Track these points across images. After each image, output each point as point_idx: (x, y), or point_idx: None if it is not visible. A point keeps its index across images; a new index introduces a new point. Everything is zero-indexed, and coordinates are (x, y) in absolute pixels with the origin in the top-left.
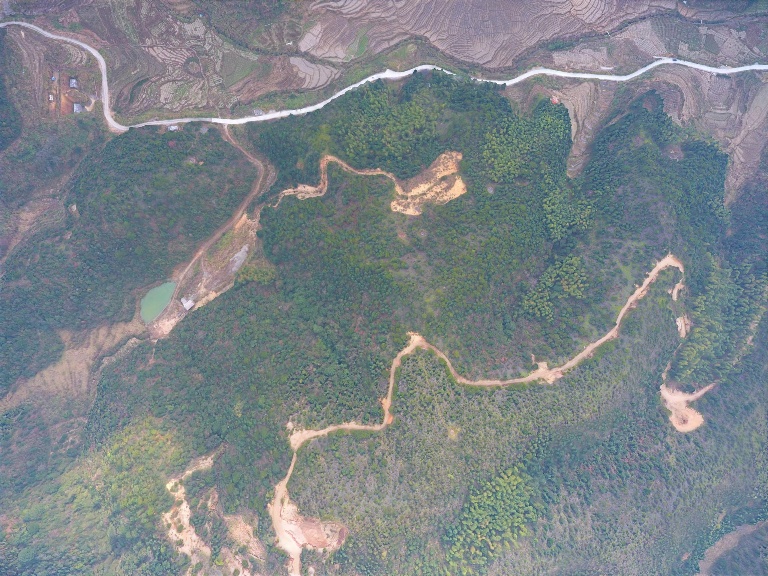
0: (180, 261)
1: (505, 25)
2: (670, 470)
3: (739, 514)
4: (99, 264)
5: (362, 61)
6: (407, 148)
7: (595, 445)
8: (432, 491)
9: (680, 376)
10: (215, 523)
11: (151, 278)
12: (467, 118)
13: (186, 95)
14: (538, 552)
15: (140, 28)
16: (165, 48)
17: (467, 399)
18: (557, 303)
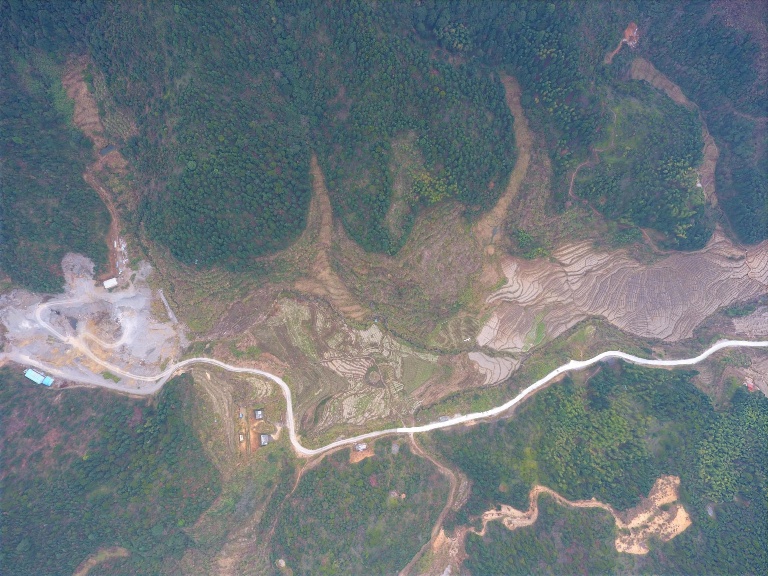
0: None
1: (683, 295)
2: None
3: None
4: None
5: (541, 348)
6: (619, 471)
7: None
8: None
9: None
10: None
11: None
12: (675, 430)
13: (369, 407)
14: None
15: (317, 342)
16: (344, 360)
17: None
18: None
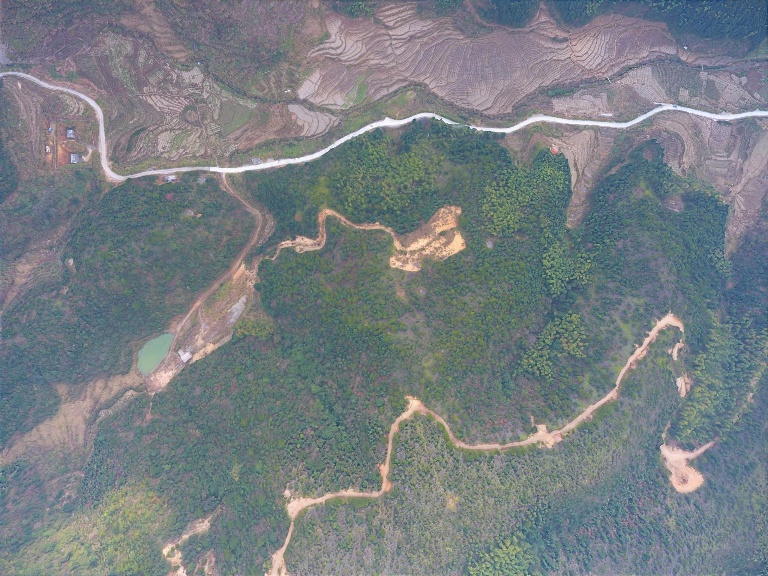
0: (177, 313)
1: (505, 71)
2: (670, 534)
3: (739, 575)
4: (96, 319)
5: (361, 108)
6: (406, 202)
7: (594, 509)
8: (430, 564)
9: (680, 435)
10: None
11: (148, 331)
12: (466, 171)
13: (184, 144)
14: None
15: (138, 76)
16: (163, 96)
17: (466, 465)
18: (556, 362)
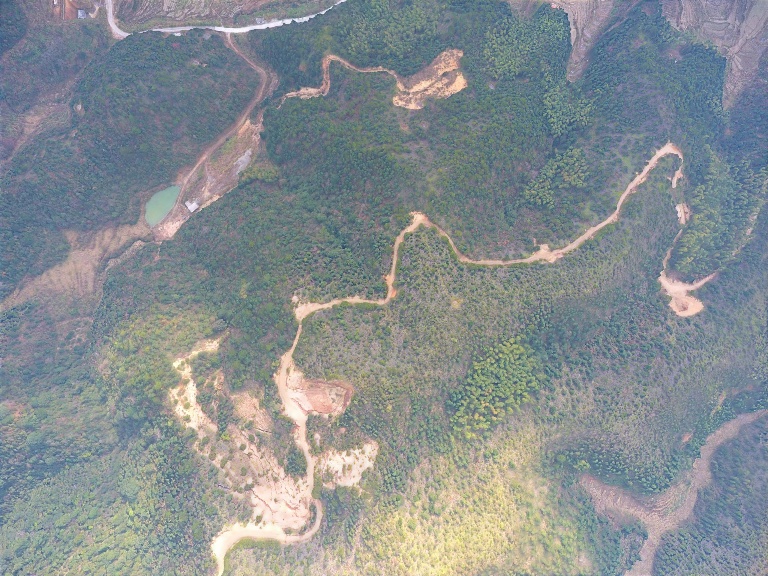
0: (184, 164)
1: None
2: (671, 348)
3: (739, 398)
4: (104, 162)
5: None
6: (408, 47)
7: (596, 324)
8: (436, 354)
9: (680, 264)
10: (221, 400)
11: (156, 180)
12: (468, 19)
13: (189, 4)
14: (541, 418)
15: None
16: None
17: (470, 274)
18: (558, 192)
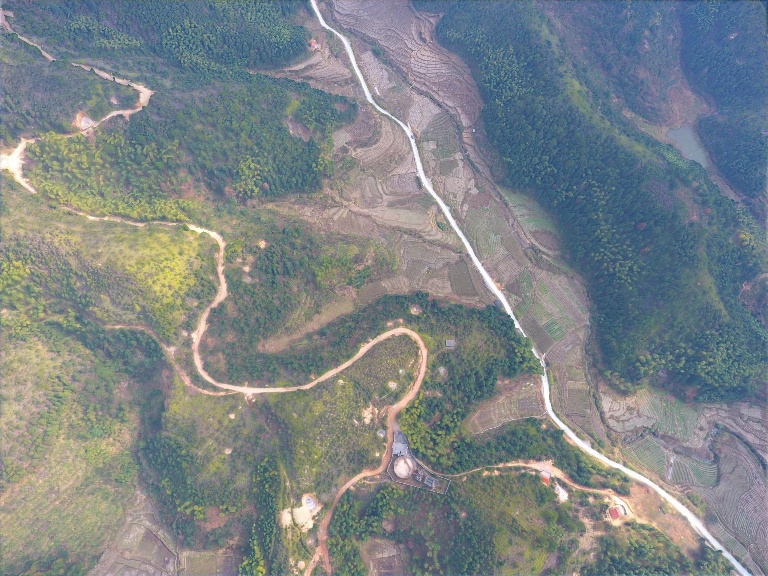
0: None
1: (376, 14)
2: None
3: None
4: None
5: None
6: None
7: None
8: None
9: None
10: None
11: None
12: None
13: None
14: None
15: None
16: None
17: None
18: None
